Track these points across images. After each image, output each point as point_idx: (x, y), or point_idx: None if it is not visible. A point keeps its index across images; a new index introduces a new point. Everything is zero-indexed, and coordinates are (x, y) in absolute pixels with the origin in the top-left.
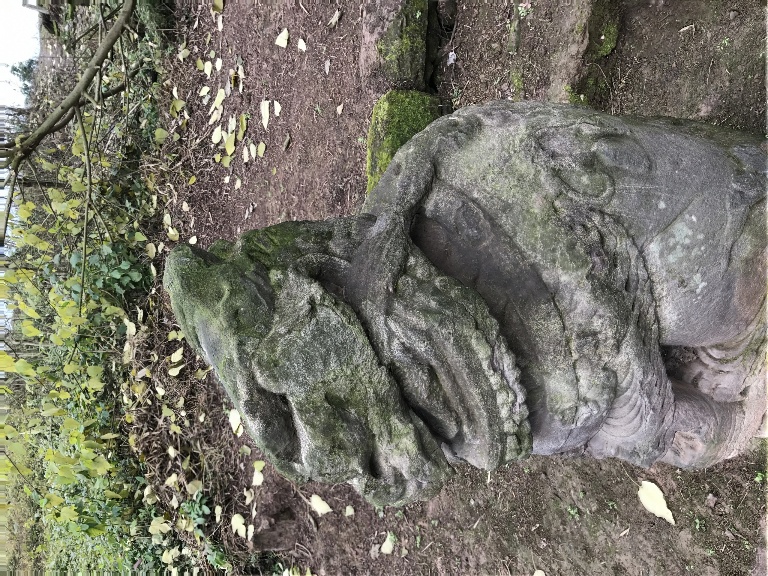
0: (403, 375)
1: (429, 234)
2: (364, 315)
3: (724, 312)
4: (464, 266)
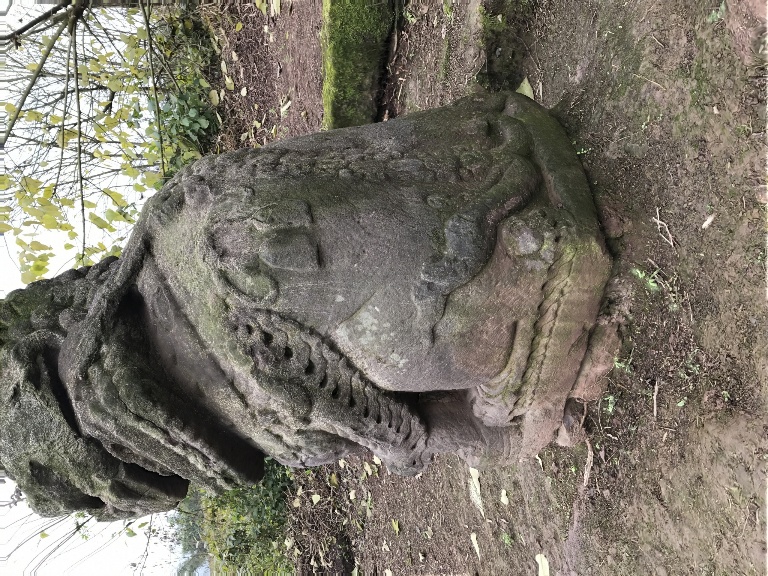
0: None
1: None
2: (68, 393)
3: (446, 375)
4: (164, 344)
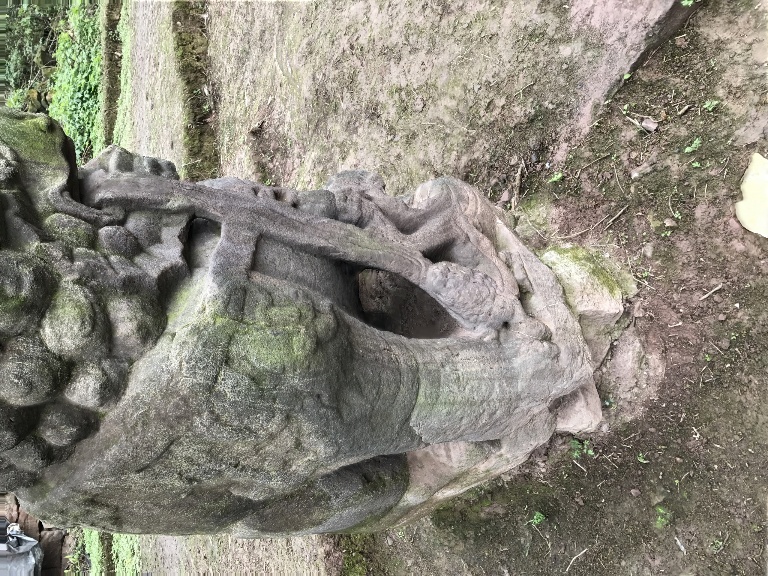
0: None
1: None
2: None
3: None
4: None
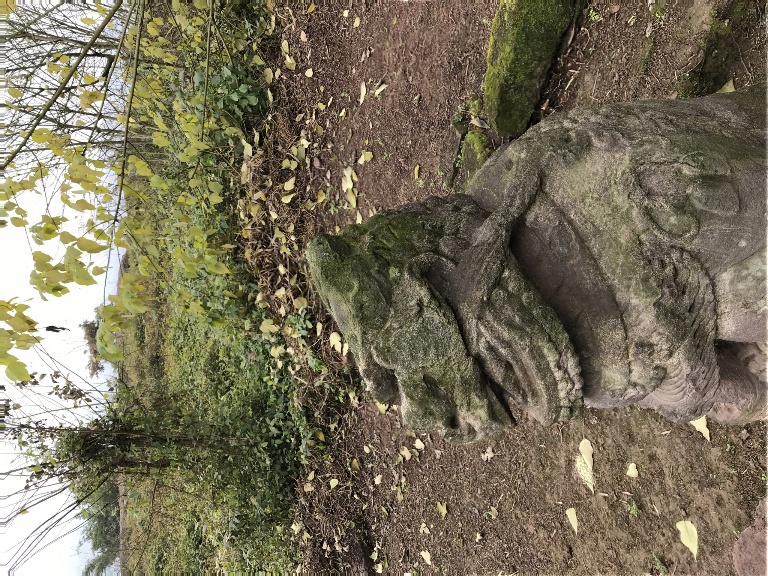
0: (485, 360)
1: (526, 239)
2: (461, 314)
3: None
4: (551, 275)
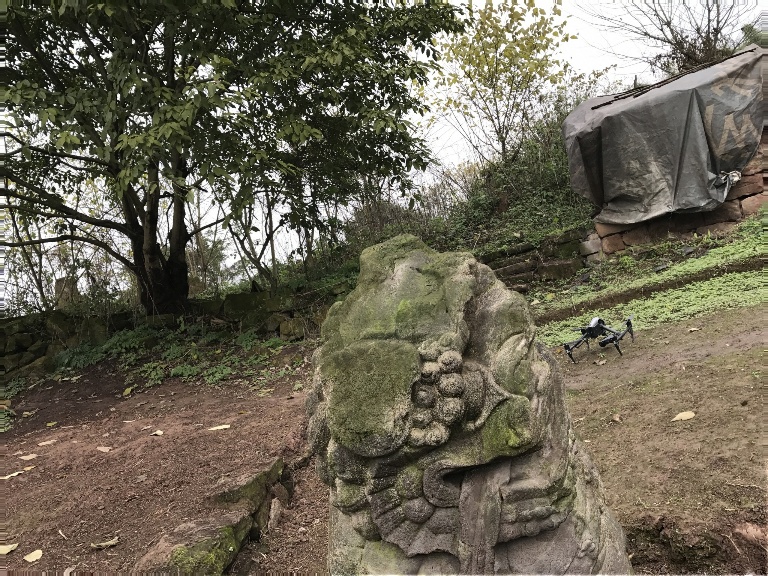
0: None
1: None
2: None
3: None
4: None
